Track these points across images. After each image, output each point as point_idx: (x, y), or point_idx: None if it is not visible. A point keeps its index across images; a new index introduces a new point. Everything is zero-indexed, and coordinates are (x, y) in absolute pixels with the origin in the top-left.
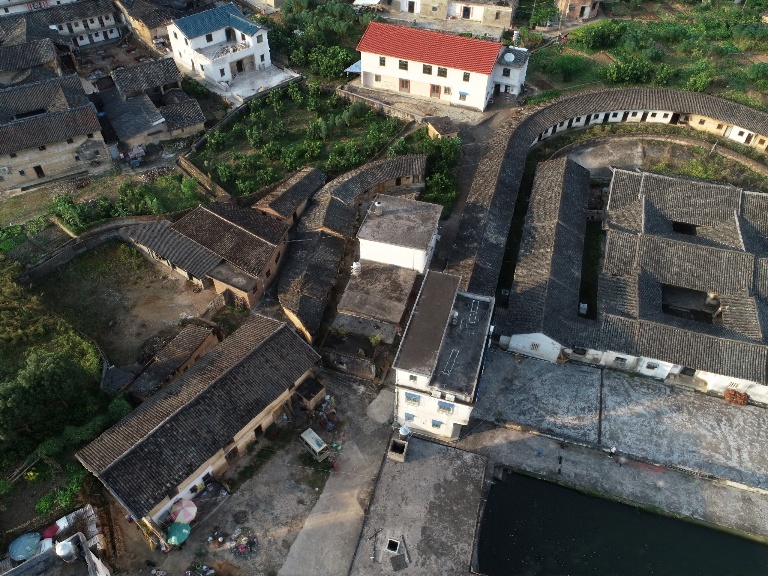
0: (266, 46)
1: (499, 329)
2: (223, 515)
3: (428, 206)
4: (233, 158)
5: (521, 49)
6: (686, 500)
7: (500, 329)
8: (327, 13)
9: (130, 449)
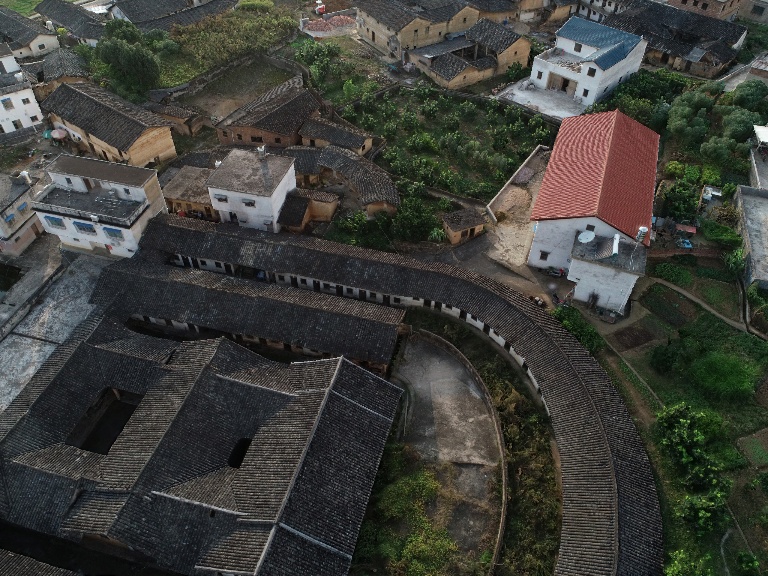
0: (596, 84)
1: (134, 256)
2: None
3: (271, 187)
4: (404, 108)
5: (614, 247)
6: None
7: (134, 257)
8: (705, 109)
9: (73, 88)
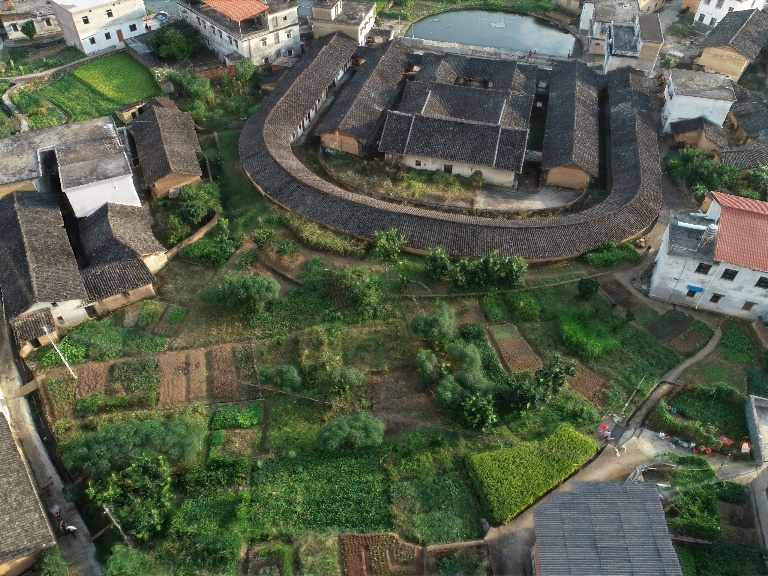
0: None
1: None
2: (698, 48)
3: (688, 93)
4: None
5: (688, 224)
6: (491, 50)
7: None
8: None
9: None
